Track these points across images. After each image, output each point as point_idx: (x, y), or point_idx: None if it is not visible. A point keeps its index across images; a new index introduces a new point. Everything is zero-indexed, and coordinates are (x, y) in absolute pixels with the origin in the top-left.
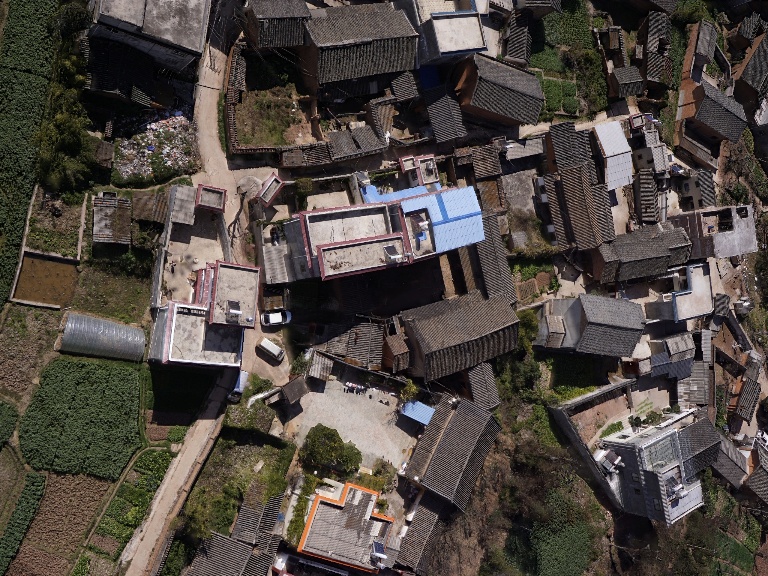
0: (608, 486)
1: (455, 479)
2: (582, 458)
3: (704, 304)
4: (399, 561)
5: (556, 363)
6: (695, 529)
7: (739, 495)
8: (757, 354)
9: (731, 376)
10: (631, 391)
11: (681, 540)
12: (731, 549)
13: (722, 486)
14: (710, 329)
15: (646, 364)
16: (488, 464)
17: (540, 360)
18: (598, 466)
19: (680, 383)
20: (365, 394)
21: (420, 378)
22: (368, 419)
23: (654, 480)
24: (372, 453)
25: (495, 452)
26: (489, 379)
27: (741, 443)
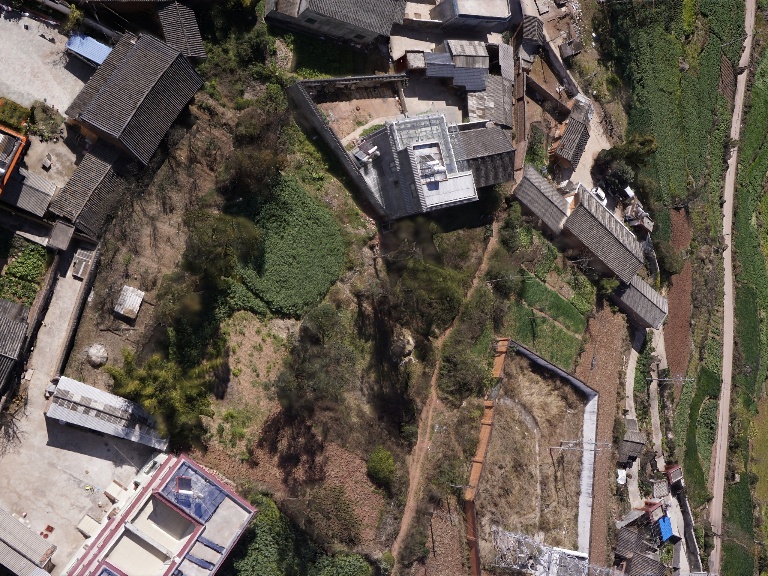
0: (364, 182)
1: (126, 116)
2: (333, 152)
3: (497, 7)
4: (53, 210)
5: (299, 43)
6: (495, 263)
7: (561, 244)
8: (585, 97)
9: (554, 121)
10: (406, 96)
11: (480, 277)
12: (551, 301)
13: (538, 231)
14: (520, 57)
15: (418, 58)
16: (200, 137)
17: (276, 35)
18: (349, 157)
19: (471, 96)
20: (18, 23)
21: (86, 3)
22: (23, 52)
23: (407, 159)
24: (28, 93)
25: (211, 126)
26: (189, 25)
27: (565, 190)
